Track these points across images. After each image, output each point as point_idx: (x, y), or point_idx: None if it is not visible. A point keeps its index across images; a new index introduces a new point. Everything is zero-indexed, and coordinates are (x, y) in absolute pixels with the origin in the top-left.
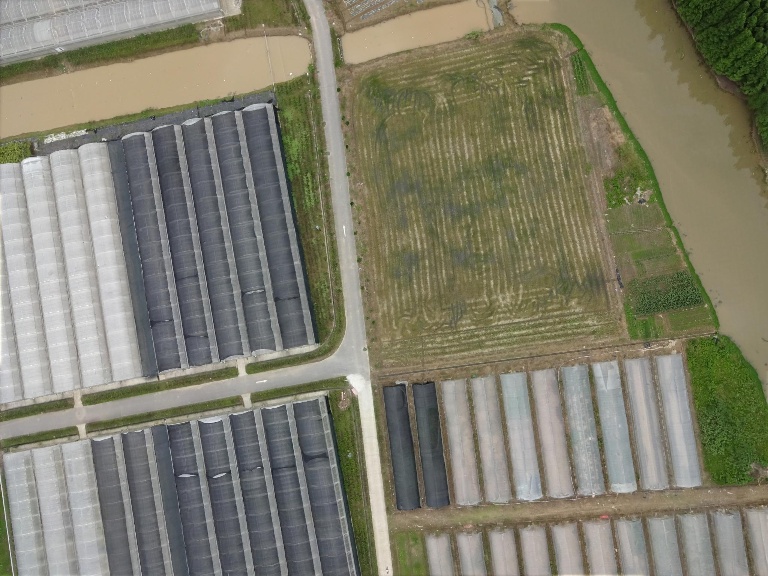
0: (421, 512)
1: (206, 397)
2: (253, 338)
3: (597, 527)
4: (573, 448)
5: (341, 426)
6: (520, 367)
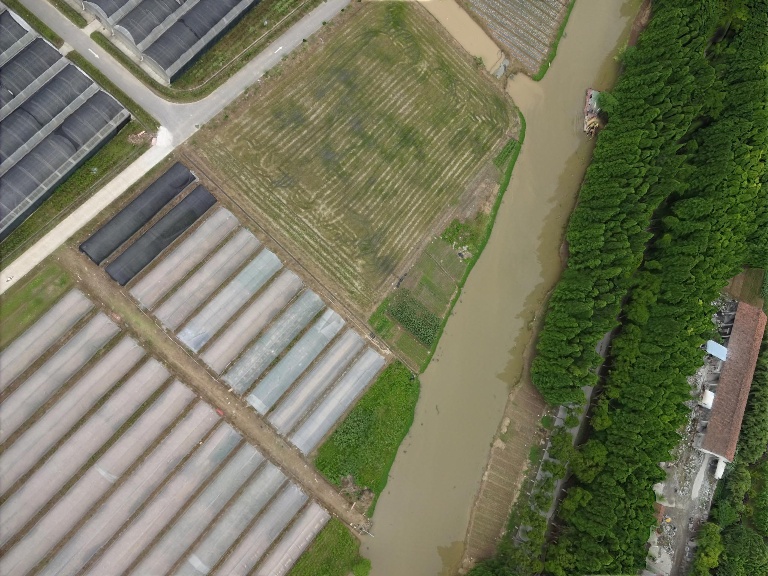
0: (94, 269)
1: (35, 9)
2: (130, 19)
3: (207, 413)
4: (255, 345)
5: (113, 149)
6: (283, 259)
